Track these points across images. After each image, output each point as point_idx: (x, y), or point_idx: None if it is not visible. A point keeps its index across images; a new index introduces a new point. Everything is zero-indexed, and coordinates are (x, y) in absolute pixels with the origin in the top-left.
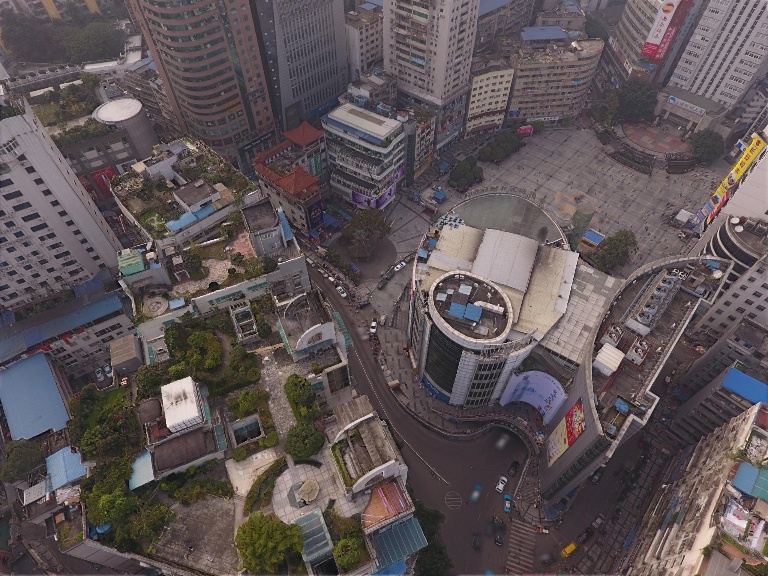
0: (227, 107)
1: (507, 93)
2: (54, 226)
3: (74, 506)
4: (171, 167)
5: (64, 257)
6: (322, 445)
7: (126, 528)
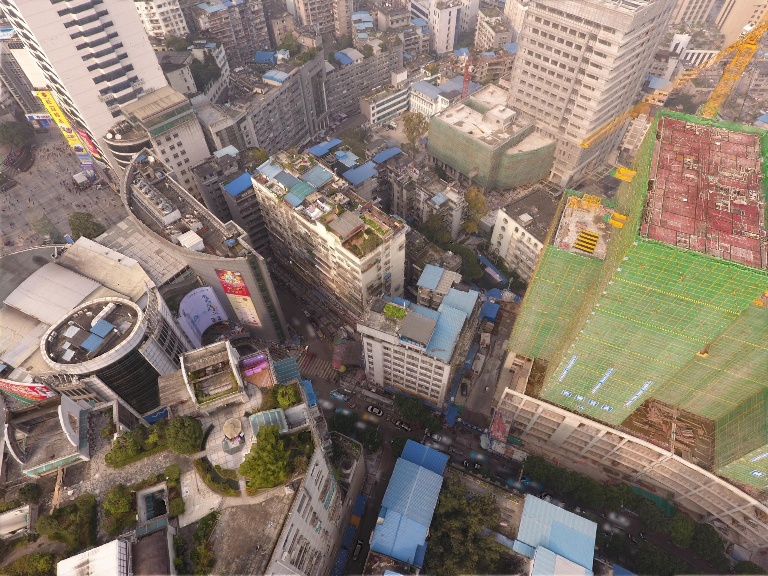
0: None
1: None
2: None
3: None
4: None
5: None
6: None
7: None
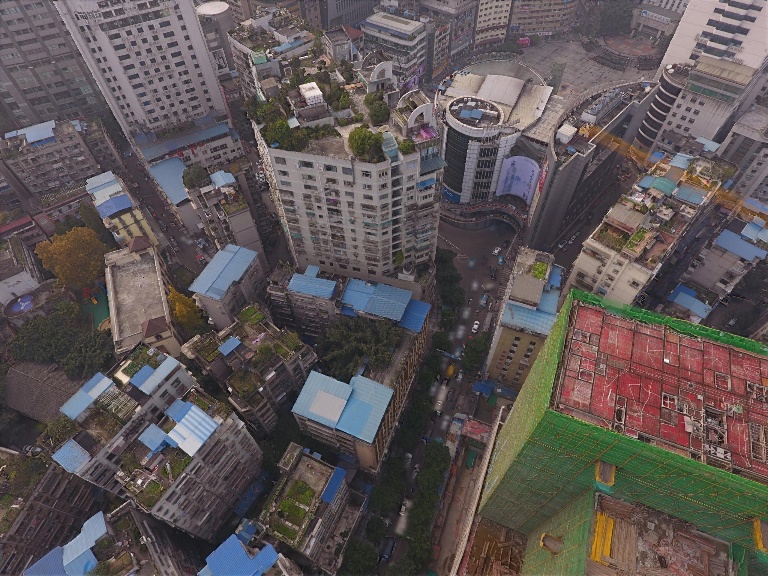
0: (289, 11)
1: (508, 9)
2: (188, 65)
3: (230, 197)
4: (268, 23)
5: (191, 92)
6: (388, 117)
7: (290, 139)
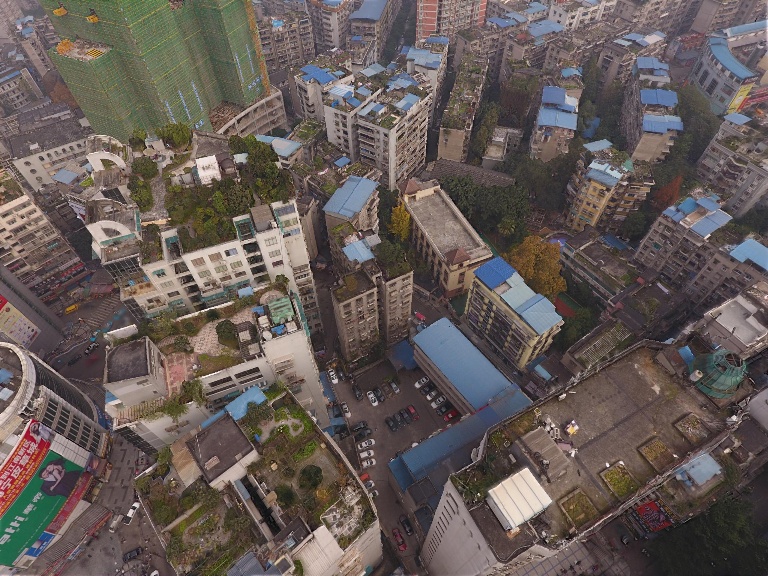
0: None
1: None
2: None
3: None
4: None
5: None
6: None
7: None
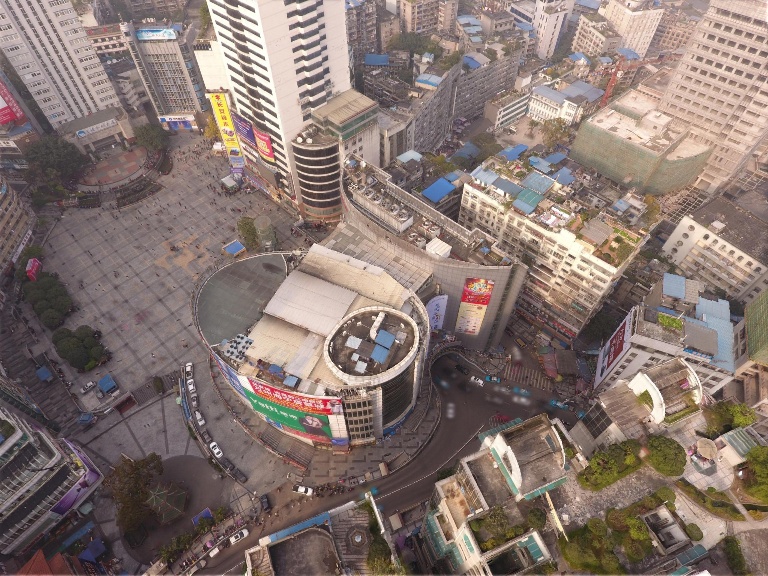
0: None
1: None
2: None
3: None
4: None
5: None
6: None
7: None
